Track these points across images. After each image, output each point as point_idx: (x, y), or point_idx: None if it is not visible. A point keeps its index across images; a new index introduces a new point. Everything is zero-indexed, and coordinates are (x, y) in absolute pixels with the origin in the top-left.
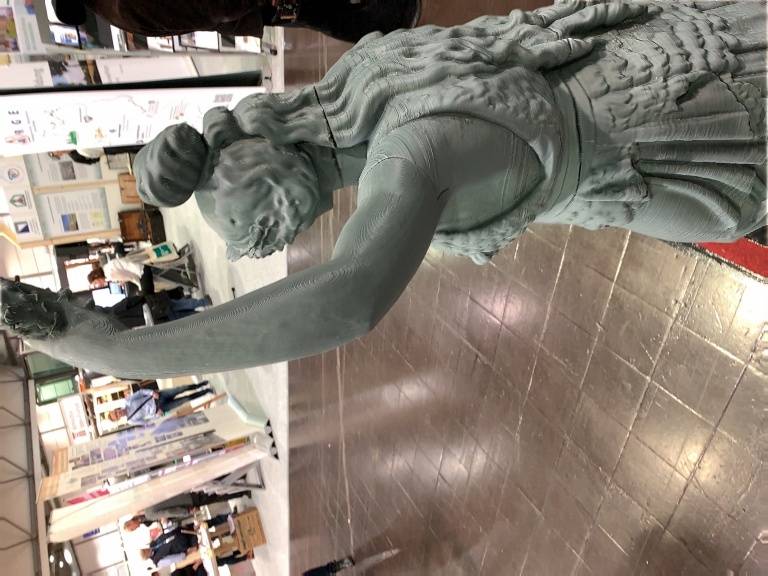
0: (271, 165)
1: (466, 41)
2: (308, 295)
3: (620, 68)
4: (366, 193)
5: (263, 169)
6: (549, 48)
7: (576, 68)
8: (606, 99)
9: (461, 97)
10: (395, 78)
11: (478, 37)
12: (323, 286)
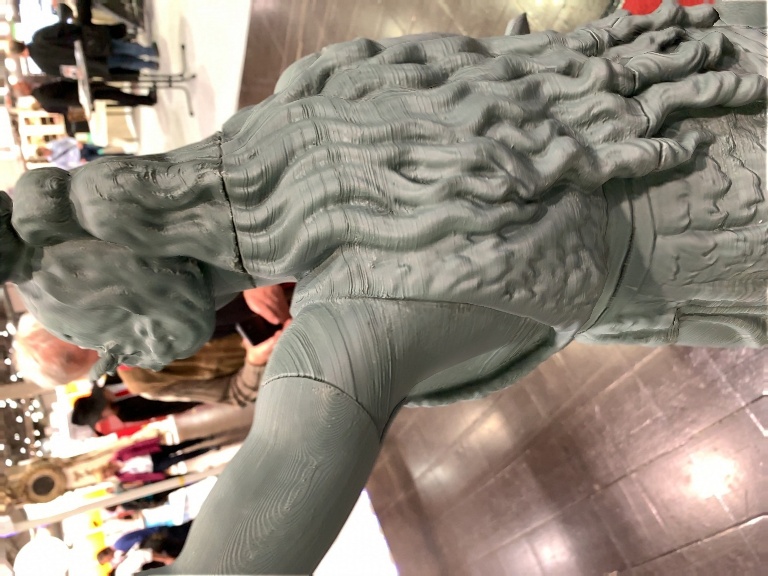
0: (131, 288)
1: (501, 152)
2: None
3: (717, 195)
4: (267, 427)
5: (116, 294)
6: (628, 161)
7: (655, 179)
8: (679, 241)
9: (462, 283)
10: (361, 219)
11: None
12: None
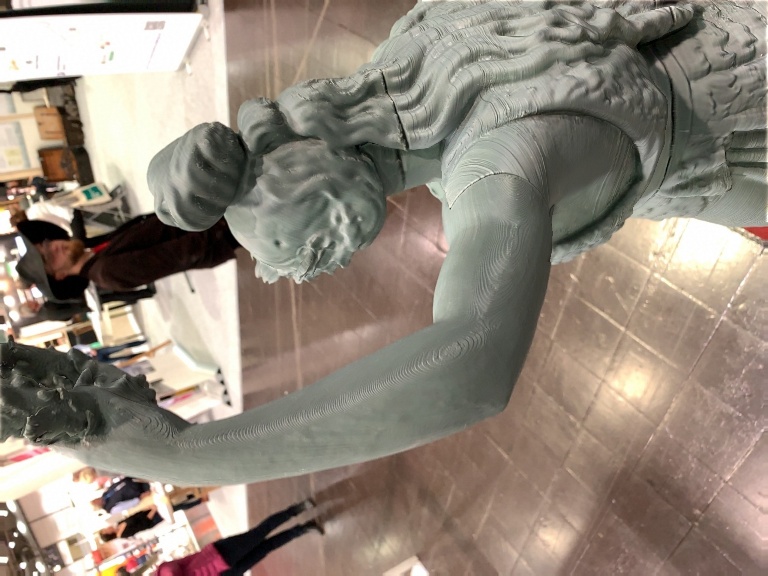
0: (329, 174)
1: (568, 13)
2: (434, 378)
3: (722, 43)
4: (468, 220)
5: (320, 180)
6: (652, 20)
7: (672, 42)
8: (707, 81)
9: (575, 91)
10: (492, 64)
11: (574, 6)
12: (451, 364)
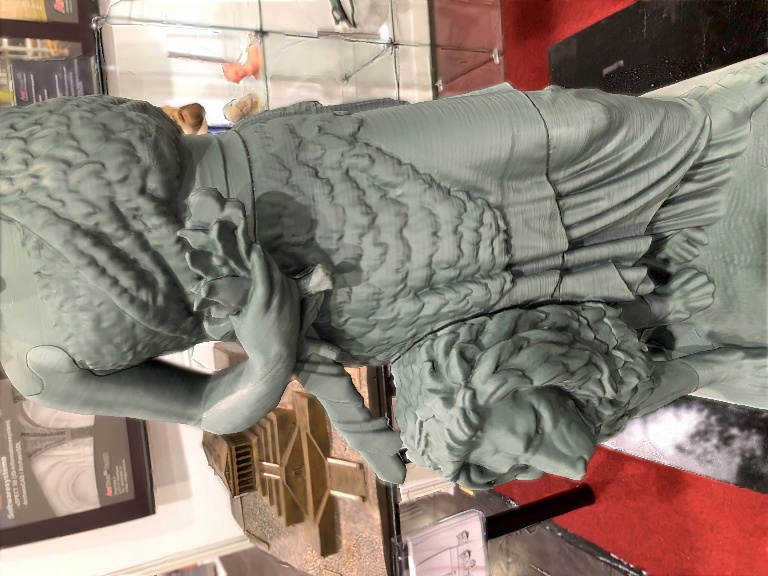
0: None
1: None
2: None
3: None
4: None
5: None
6: None
7: None
8: None
9: None
10: None
11: None
12: None
